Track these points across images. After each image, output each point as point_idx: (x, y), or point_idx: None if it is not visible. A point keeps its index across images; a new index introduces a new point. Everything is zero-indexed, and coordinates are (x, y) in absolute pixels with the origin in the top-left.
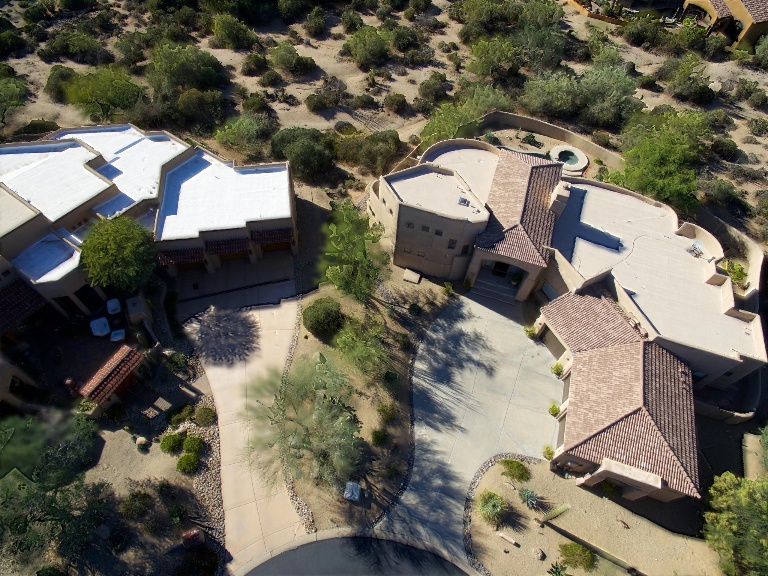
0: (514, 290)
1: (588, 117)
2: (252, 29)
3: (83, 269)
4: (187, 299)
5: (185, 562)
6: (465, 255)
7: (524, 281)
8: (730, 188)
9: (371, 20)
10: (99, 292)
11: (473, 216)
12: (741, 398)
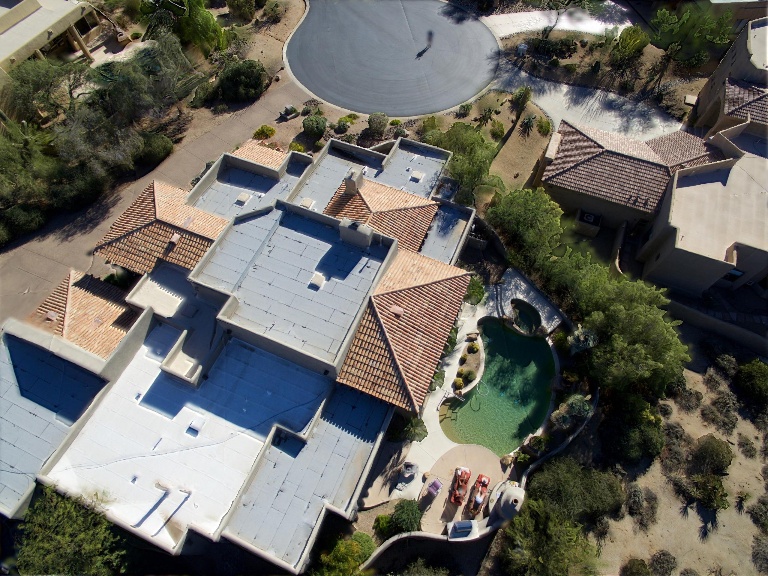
0: None
1: None
2: None
3: None
4: (628, 1)
5: (485, 1)
6: None
7: None
8: None
9: None
10: None
11: (759, 63)
12: None
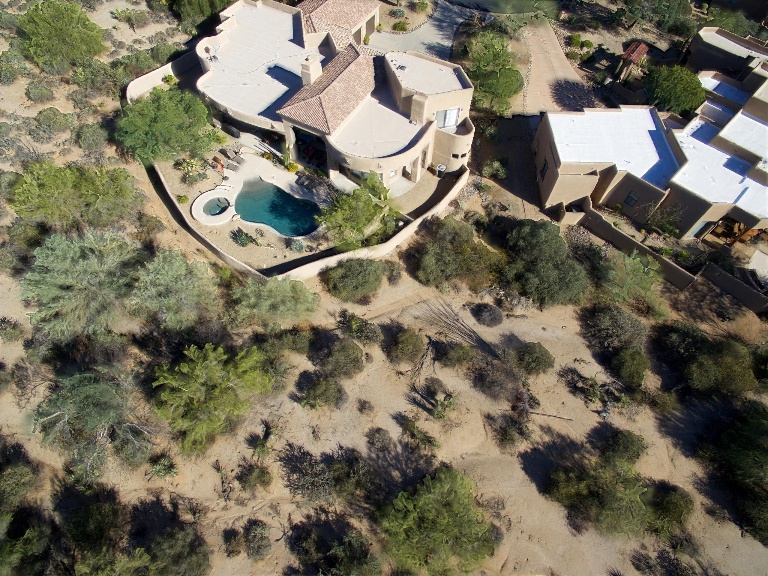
0: None
1: None
2: None
3: None
4: None
5: None
6: None
7: None
8: None
9: None
10: None
11: (399, 58)
12: None
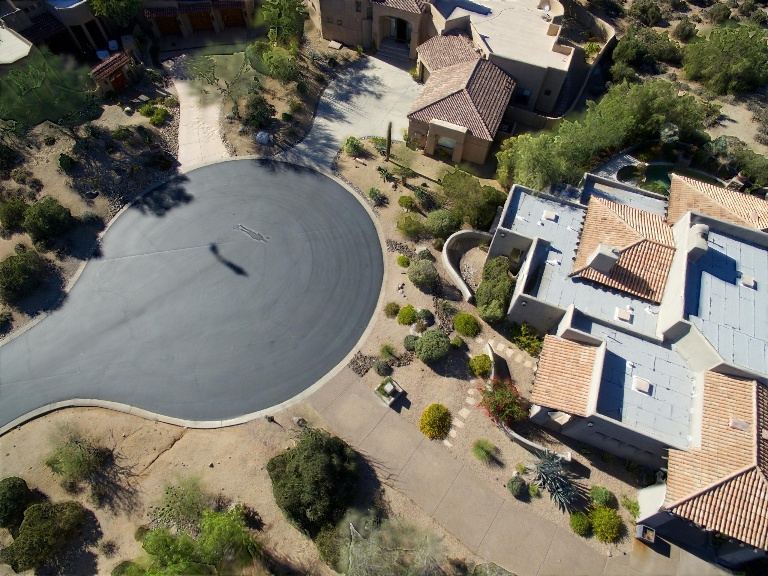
0: None
1: None
2: None
3: (90, 4)
4: (167, 51)
5: (151, 160)
6: (370, 19)
7: (411, 35)
8: None
9: None
10: (103, 32)
11: None
12: None
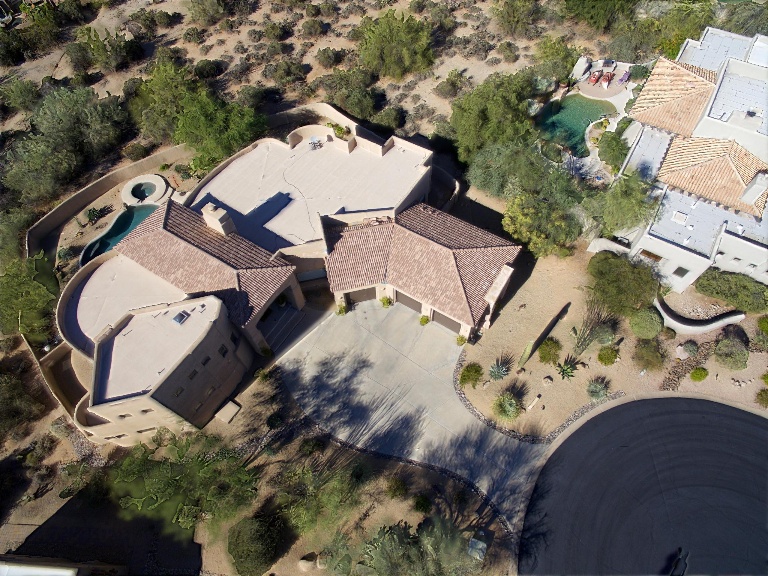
0: (290, 308)
1: (99, 149)
2: None
3: None
4: None
5: None
6: (238, 342)
7: (293, 294)
8: (254, 89)
9: None
10: None
11: (207, 315)
12: (440, 183)
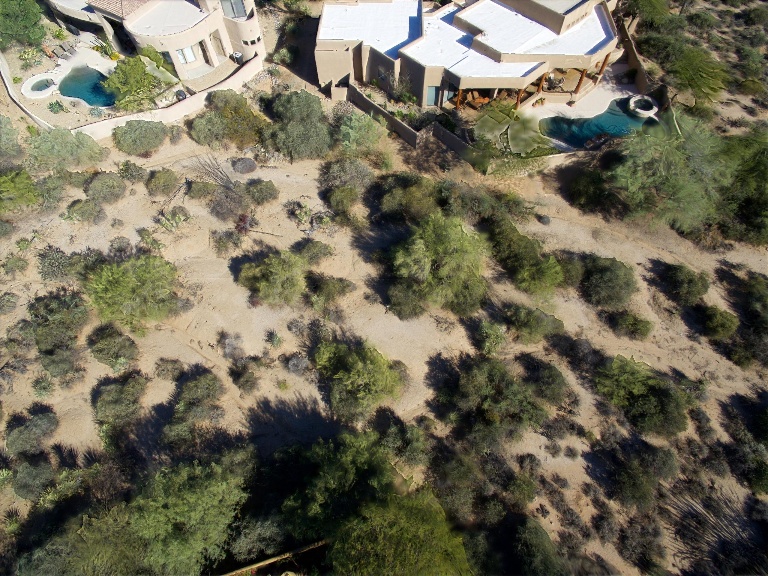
0: None
1: None
2: (326, 439)
3: None
4: None
5: None
6: None
7: None
8: None
9: (76, 421)
10: None
11: None
12: None
